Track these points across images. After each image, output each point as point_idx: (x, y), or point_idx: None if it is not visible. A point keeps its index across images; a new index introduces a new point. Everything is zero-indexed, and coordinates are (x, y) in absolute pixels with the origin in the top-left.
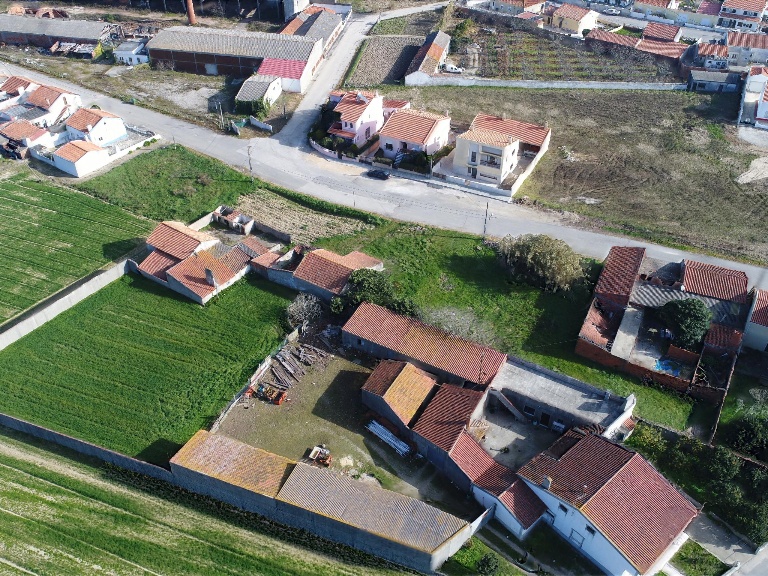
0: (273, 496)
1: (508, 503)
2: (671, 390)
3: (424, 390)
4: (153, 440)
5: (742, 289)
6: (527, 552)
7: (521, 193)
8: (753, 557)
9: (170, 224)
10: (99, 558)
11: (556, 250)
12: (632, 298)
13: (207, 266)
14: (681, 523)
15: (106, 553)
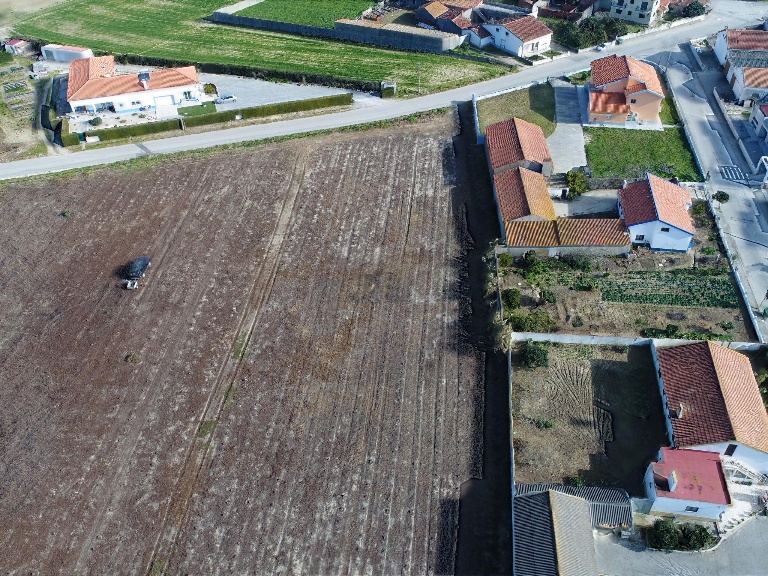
0: (379, 28)
1: (476, 31)
2: (560, 19)
3: (444, 10)
4: None
5: None
6: None
7: None
8: (577, 54)
9: None
10: (307, 53)
11: None
12: None
13: None
14: (545, 33)
15: None
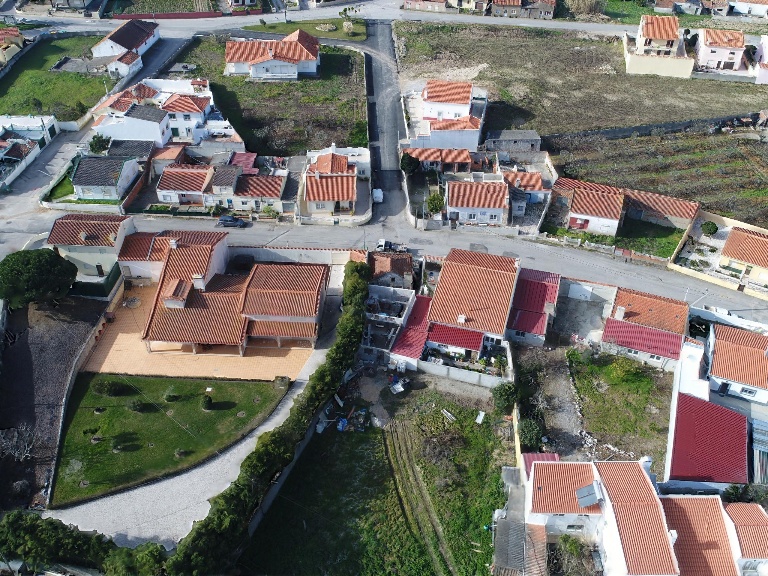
0: None
1: None
2: None
3: None
4: None
5: None
6: None
7: None
8: None
9: None
10: None
11: None
12: None
13: None
14: None
15: None
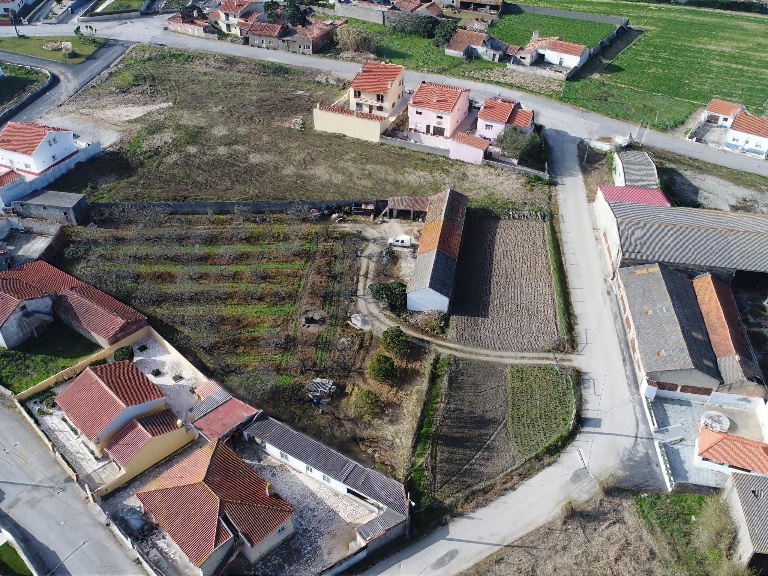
0: None
1: None
2: None
3: None
4: None
5: None
6: None
7: None
8: None
9: (581, 47)
10: None
11: None
12: None
13: None
14: None
15: None
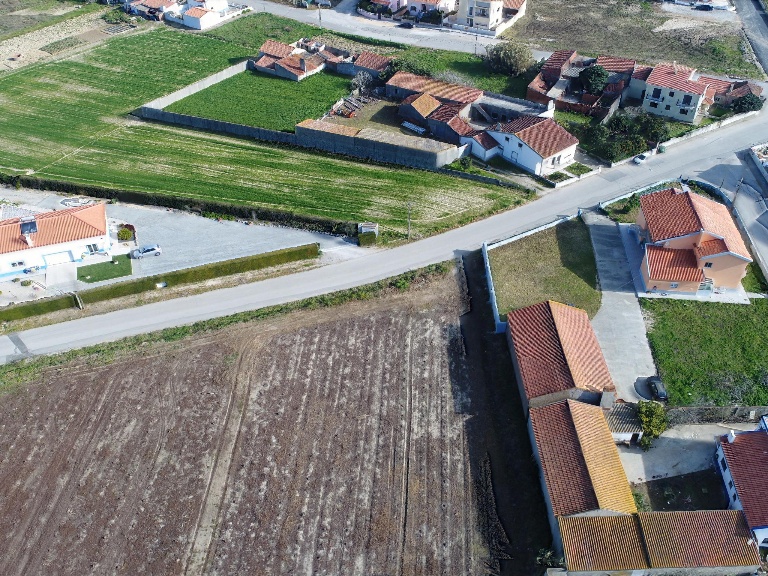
0: (353, 136)
1: (479, 140)
2: (581, 113)
3: (435, 105)
4: (280, 130)
5: (631, 66)
6: (488, 165)
7: (503, 35)
8: (610, 169)
9: None
10: (260, 168)
11: (519, 48)
12: (564, 73)
13: (299, 62)
14: (569, 144)
15: (264, 167)
